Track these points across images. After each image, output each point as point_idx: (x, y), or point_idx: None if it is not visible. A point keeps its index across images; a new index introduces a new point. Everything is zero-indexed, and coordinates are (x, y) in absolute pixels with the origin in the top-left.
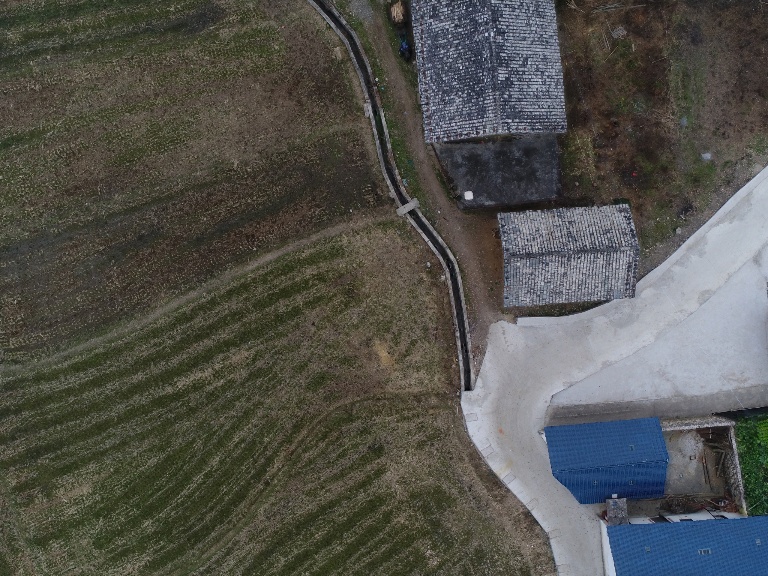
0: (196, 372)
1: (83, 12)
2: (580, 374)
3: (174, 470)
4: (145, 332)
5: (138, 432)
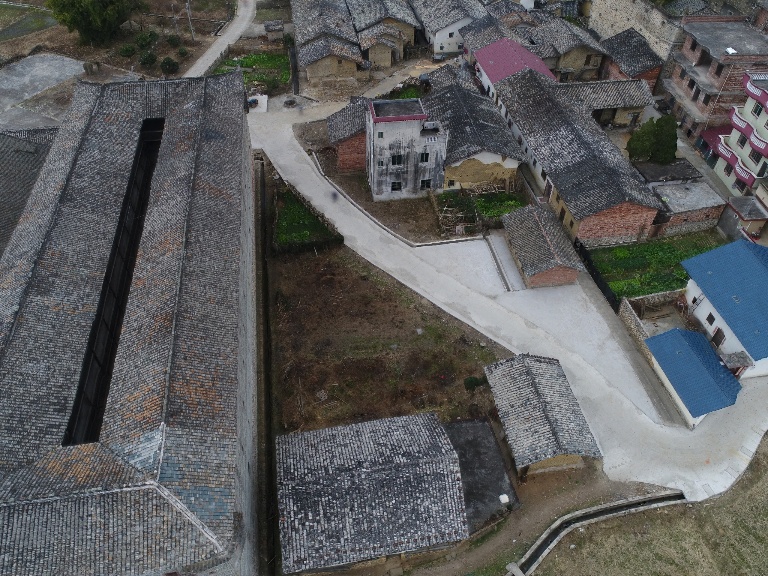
0: None
1: None
2: (626, 403)
3: None
4: None
5: None
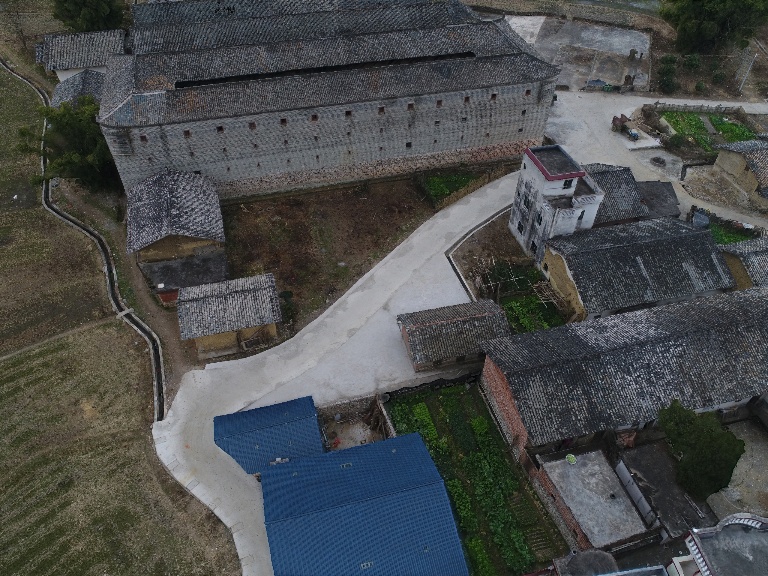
0: None
1: None
2: (258, 394)
3: None
4: None
5: None
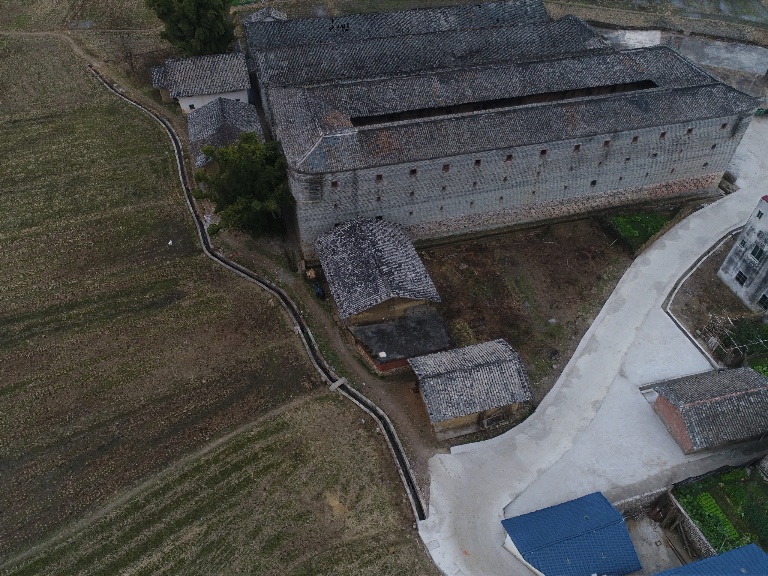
0: (144, 559)
1: (78, 307)
2: (521, 485)
3: None
4: (93, 529)
5: None
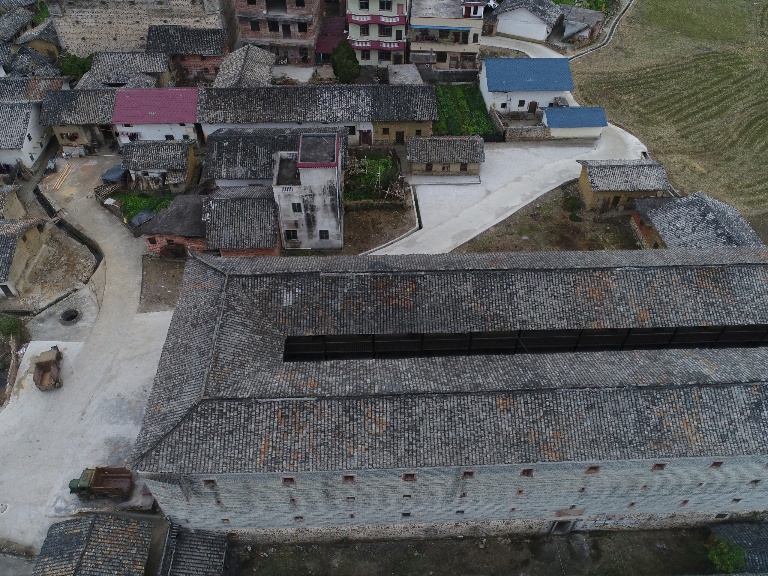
0: None
1: None
2: None
3: None
4: None
5: None
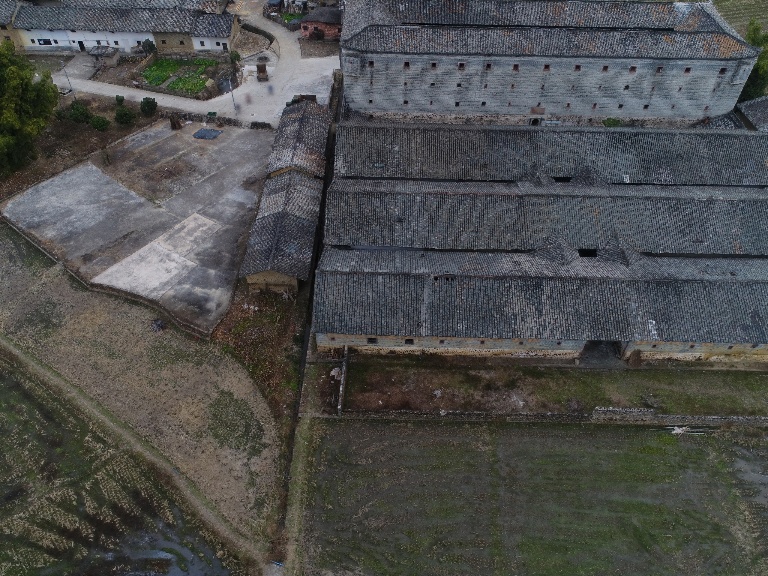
0: None
1: None
2: None
3: (714, 2)
4: None
5: (731, 8)
